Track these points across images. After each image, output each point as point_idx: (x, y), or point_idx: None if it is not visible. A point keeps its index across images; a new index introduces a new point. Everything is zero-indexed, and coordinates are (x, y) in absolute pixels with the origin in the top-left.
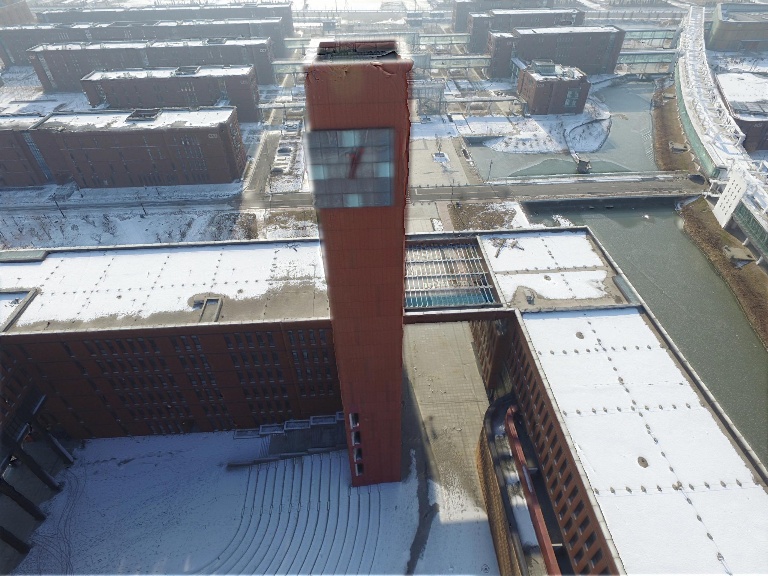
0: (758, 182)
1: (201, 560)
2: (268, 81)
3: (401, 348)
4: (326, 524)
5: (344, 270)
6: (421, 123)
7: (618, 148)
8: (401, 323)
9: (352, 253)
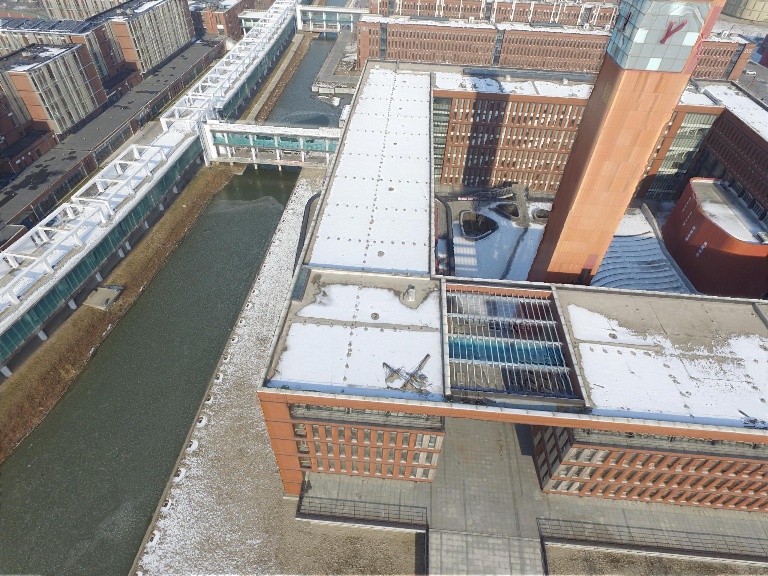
0: None
1: None
2: None
3: None
4: None
5: None
6: None
7: None
8: None
9: None
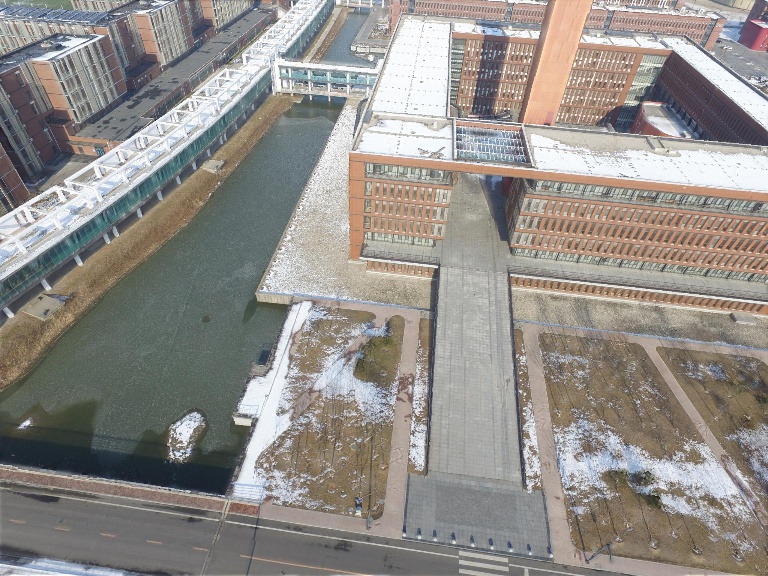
0: None
1: None
2: None
3: None
4: None
5: None
6: None
7: None
8: None
9: None
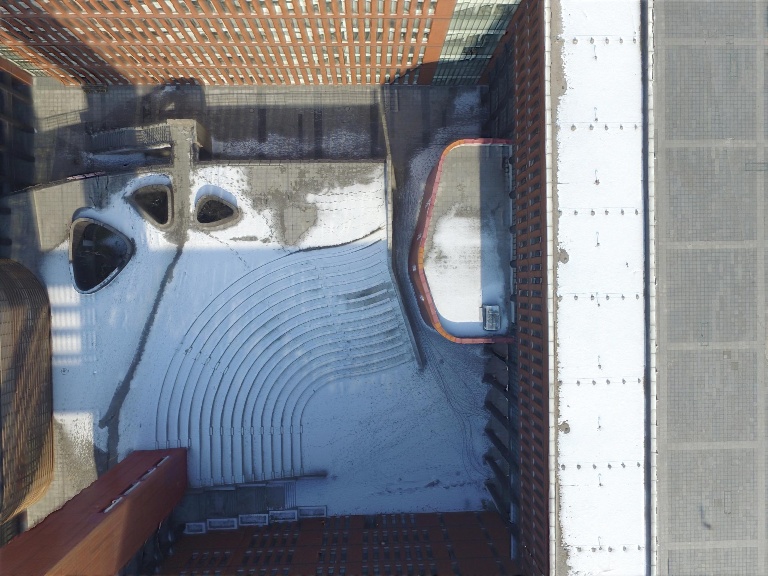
0: None
1: (330, 390)
2: None
3: None
4: (212, 414)
5: None
6: None
7: None
8: None
9: None
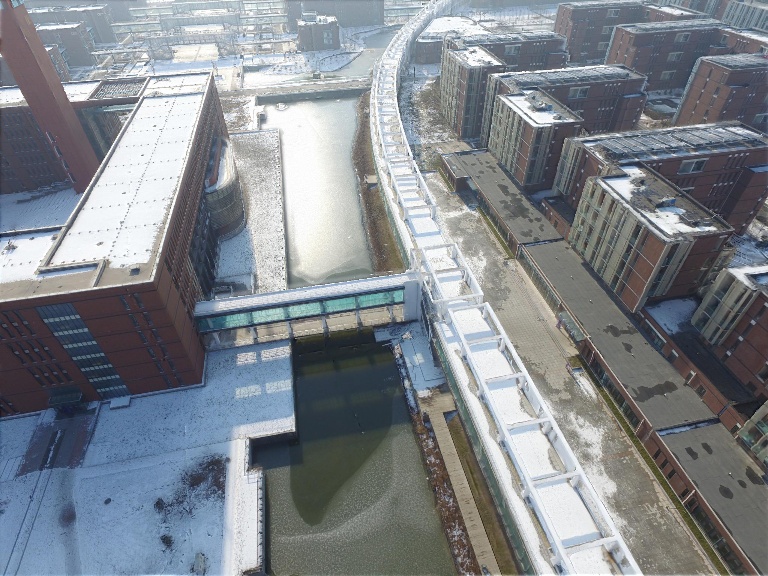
0: (394, 71)
1: None
2: (110, 40)
3: (49, 87)
4: None
5: (2, 41)
6: (218, 60)
7: (351, 68)
8: (41, 71)
9: (1, 32)
